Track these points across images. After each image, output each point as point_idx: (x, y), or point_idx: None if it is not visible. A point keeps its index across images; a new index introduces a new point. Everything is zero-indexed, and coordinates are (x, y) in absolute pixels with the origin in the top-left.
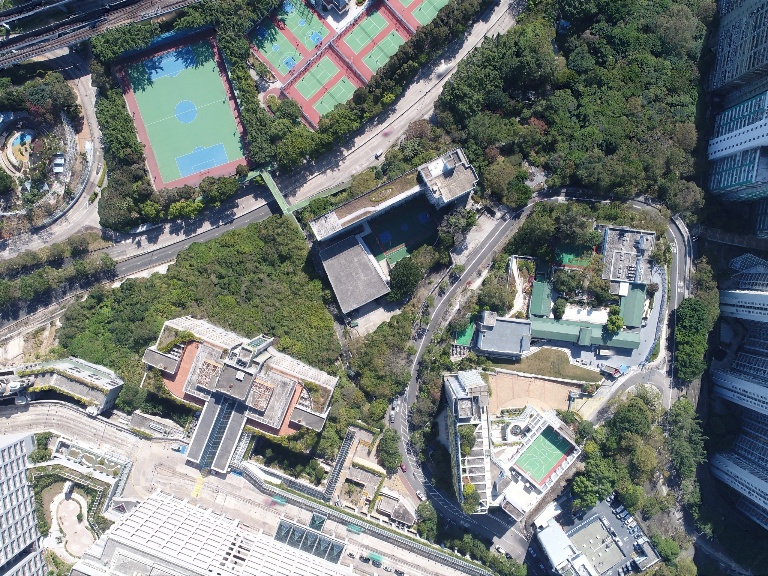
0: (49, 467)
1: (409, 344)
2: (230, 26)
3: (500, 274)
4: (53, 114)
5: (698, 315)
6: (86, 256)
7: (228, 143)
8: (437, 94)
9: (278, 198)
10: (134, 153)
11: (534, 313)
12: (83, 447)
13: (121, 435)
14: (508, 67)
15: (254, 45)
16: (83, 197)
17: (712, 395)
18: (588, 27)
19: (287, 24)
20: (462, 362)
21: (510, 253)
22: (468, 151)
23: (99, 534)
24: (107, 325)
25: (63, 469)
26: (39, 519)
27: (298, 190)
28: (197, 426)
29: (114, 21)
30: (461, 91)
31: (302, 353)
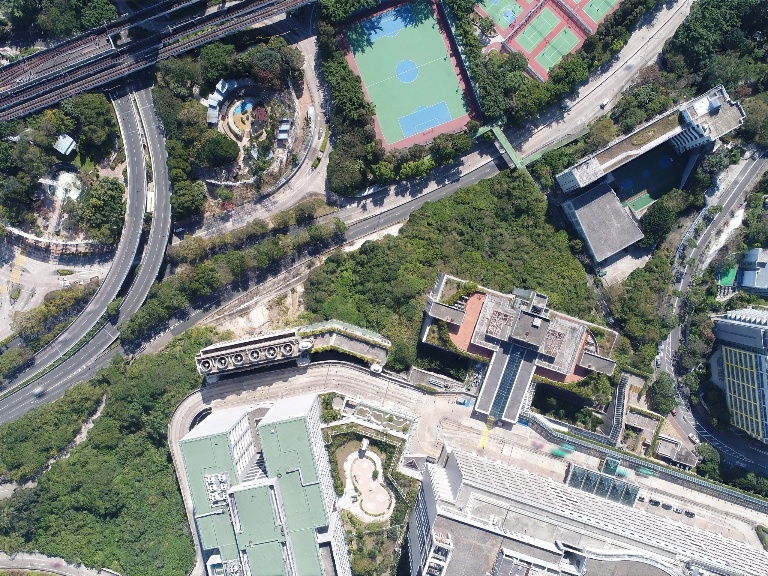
0: (342, 426)
1: (669, 288)
2: None
3: (759, 212)
4: (280, 79)
5: None
6: (311, 223)
7: (451, 101)
8: (660, 40)
9: (510, 152)
10: (367, 114)
11: None
12: (371, 405)
13: (404, 391)
14: (747, 5)
15: None
16: (305, 163)
17: None
18: None
19: None
20: (732, 301)
21: (764, 191)
22: None
23: (399, 490)
24: (353, 288)
25: (357, 427)
26: (335, 479)
27: (524, 144)
28: (486, 377)
29: None
30: (697, 33)
31: (560, 303)
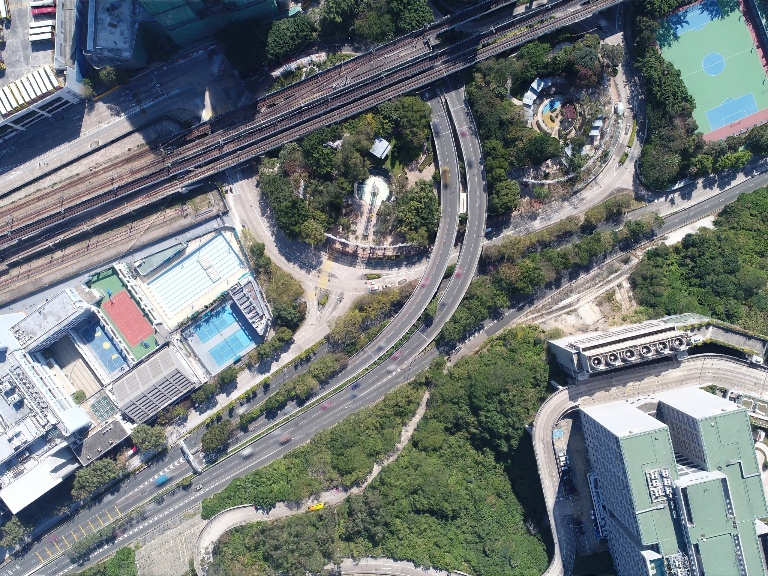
0: None
1: None
2: None
3: None
4: (598, 76)
5: None
6: (619, 218)
7: (757, 92)
8: None
9: None
10: None
11: None
12: None
13: None
14: None
15: None
16: (612, 159)
17: None
18: None
19: None
20: None
21: None
22: None
23: None
24: (686, 281)
25: None
26: None
27: None
28: None
29: None
30: None
31: None
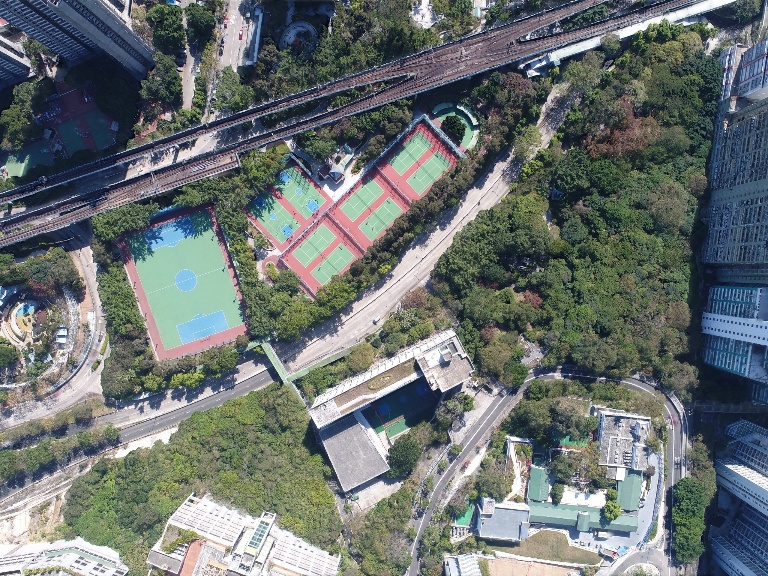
0: None
1: (409, 523)
2: (228, 202)
3: (498, 455)
4: (55, 290)
5: (695, 498)
6: (90, 422)
7: (228, 310)
8: (433, 260)
9: (278, 368)
10: (135, 329)
11: (532, 498)
12: None
13: None
14: (502, 243)
15: (252, 214)
16: (86, 364)
17: (711, 561)
18: (581, 197)
19: (284, 193)
20: (462, 547)
21: (508, 431)
22: (464, 330)
23: None
24: (111, 501)
25: None
26: None
27: (297, 355)
28: None
29: (114, 200)
30: (456, 265)
31: (304, 532)
